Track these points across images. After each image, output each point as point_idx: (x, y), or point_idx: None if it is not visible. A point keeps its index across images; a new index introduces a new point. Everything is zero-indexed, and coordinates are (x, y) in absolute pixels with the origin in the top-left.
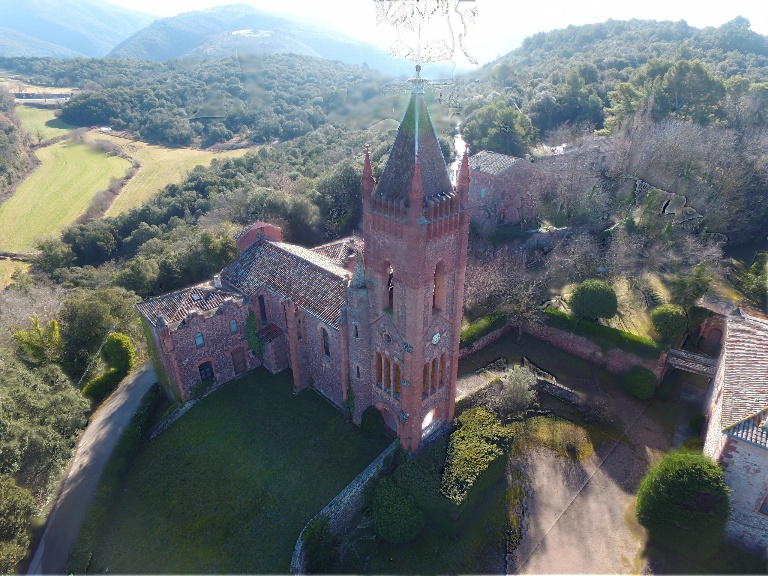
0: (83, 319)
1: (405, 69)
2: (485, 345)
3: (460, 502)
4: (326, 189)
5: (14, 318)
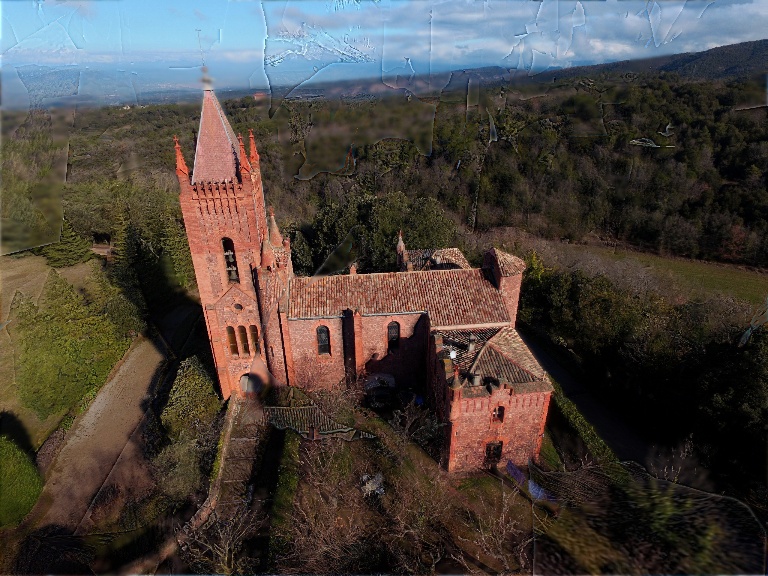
0: (553, 281)
1: (357, 72)
2: None
3: None
4: None
5: (592, 269)
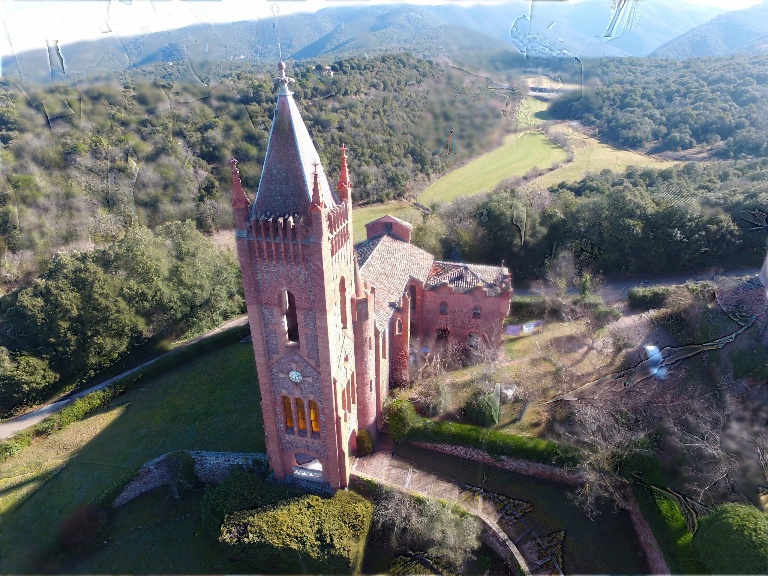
0: None
1: None
2: (536, 475)
3: (227, 542)
4: (583, 214)
5: None
